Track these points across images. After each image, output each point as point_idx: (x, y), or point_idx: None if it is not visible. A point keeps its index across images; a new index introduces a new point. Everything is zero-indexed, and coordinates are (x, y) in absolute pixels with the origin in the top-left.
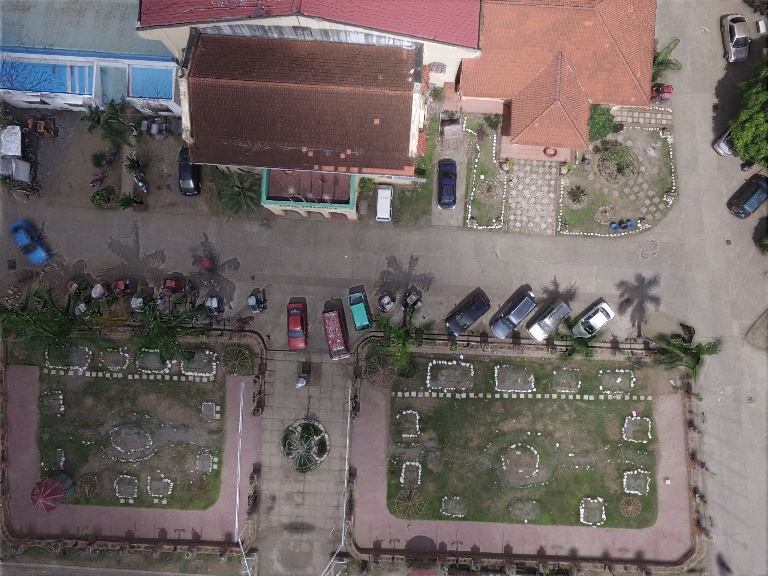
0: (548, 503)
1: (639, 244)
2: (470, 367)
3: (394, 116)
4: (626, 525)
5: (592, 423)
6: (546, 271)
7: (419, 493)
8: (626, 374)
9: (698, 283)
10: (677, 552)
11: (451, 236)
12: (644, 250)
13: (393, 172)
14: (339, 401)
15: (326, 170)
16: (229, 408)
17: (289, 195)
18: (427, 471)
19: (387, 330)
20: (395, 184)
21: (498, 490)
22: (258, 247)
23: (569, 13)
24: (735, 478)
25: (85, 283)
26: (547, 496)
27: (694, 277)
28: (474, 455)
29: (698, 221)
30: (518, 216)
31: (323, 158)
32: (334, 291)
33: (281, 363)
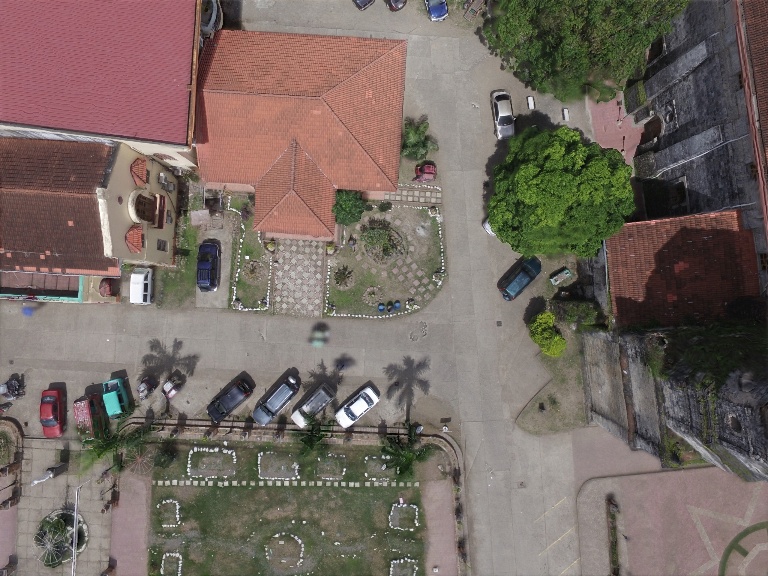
0: None
1: (408, 326)
2: (232, 455)
3: (88, 218)
4: None
5: (359, 510)
6: (313, 354)
7: None
8: None
9: (468, 365)
10: None
11: (216, 318)
12: (413, 332)
13: (98, 273)
14: (99, 490)
15: (29, 271)
16: None
17: (22, 286)
18: (188, 562)
19: (150, 416)
20: (157, 266)
21: None
22: (17, 331)
23: (295, 102)
24: (505, 565)
25: None
26: None
27: (464, 359)
28: (237, 545)
29: (468, 302)
30: (284, 297)
31: (23, 259)
32: (95, 376)
33: (39, 451)
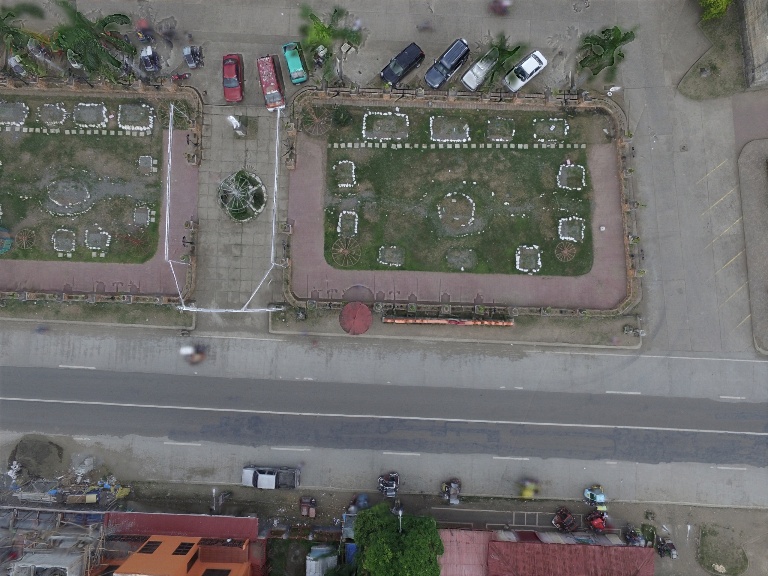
0: (484, 252)
1: None
2: (405, 117)
3: None
4: (562, 272)
5: (527, 172)
6: (480, 25)
7: (355, 240)
8: (560, 122)
9: None
10: (613, 298)
11: None
12: (577, 3)
13: None
14: None
15: None
16: (166, 162)
17: None
18: (364, 221)
19: None
20: None
21: (435, 239)
22: (195, 5)
23: None
24: (669, 225)
25: (22, 41)
26: (483, 245)
27: (626, 29)
28: (410, 205)
29: None
30: None
31: None
32: (270, 48)
33: (218, 117)
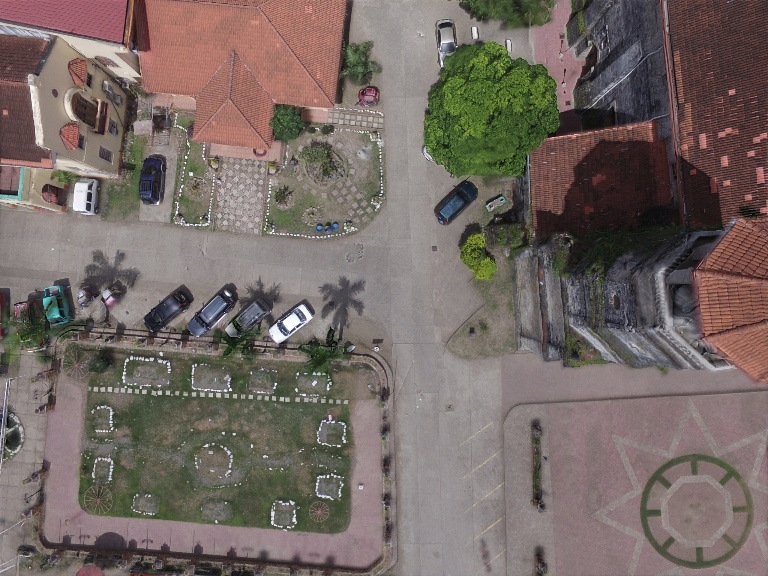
0: (240, 504)
1: (345, 247)
2: (166, 364)
3: (21, 107)
4: (318, 530)
5: (288, 425)
6: (251, 271)
7: (108, 489)
8: (322, 377)
9: (402, 288)
10: (368, 559)
11: (158, 232)
12: (350, 253)
13: (32, 164)
14: None
15: None
16: None
17: None
18: (120, 467)
19: None
20: (103, 178)
21: (191, 489)
22: None
23: (233, 11)
24: (430, 486)
25: None
26: (240, 497)
27: (398, 282)
28: (168, 453)
29: (405, 226)
30: (225, 214)
31: None
32: (39, 283)
33: None
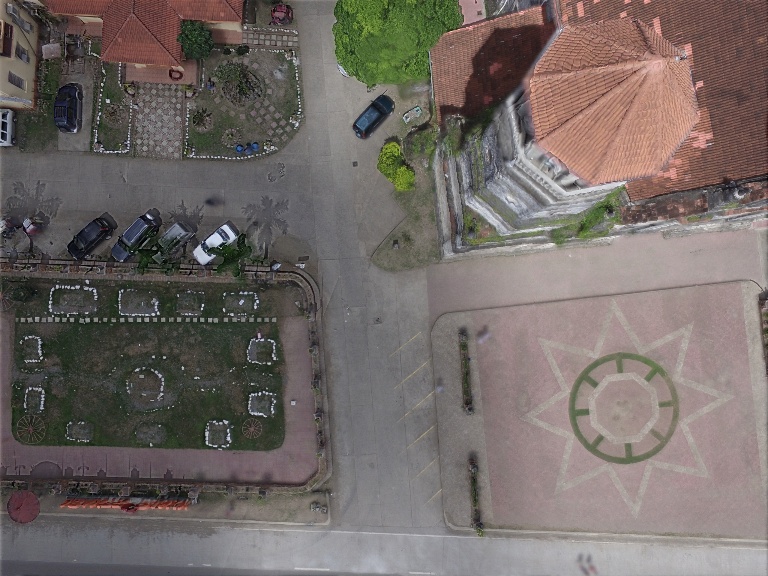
0: (174, 427)
1: (266, 167)
2: (93, 291)
3: None
4: (253, 447)
5: (218, 346)
6: (174, 195)
7: (40, 418)
8: (249, 296)
9: (325, 205)
10: (304, 473)
11: (78, 161)
12: (271, 173)
13: None
14: None
15: None
16: None
17: None
18: (51, 396)
19: (14, 256)
20: (19, 109)
21: (124, 414)
22: None
23: None
24: (362, 399)
25: None
26: (173, 420)
27: (321, 199)
28: (99, 380)
29: (324, 143)
30: (145, 140)
31: None
32: None
33: None
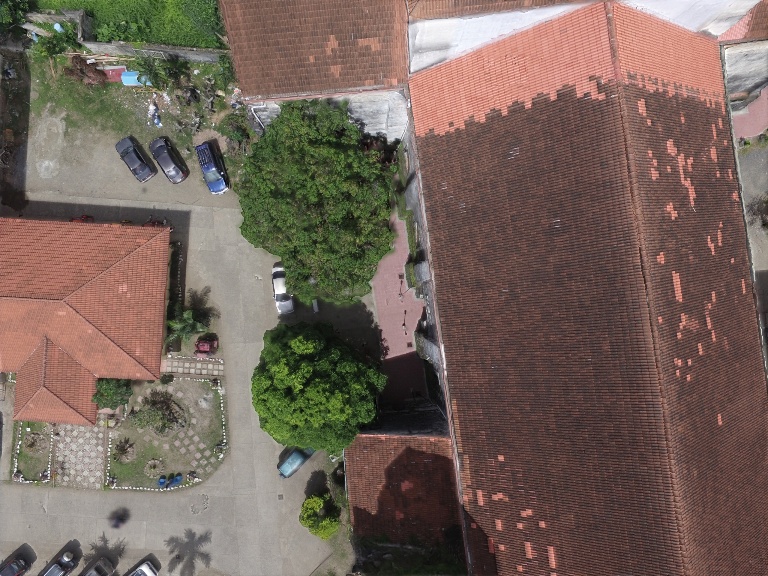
0: None
1: (190, 498)
2: None
3: None
4: None
5: None
6: (94, 526)
7: None
8: None
9: (249, 539)
10: None
11: None
12: (195, 505)
13: None
14: None
15: None
16: None
17: None
18: None
19: None
20: None
21: None
22: None
23: (38, 305)
24: None
25: None
26: None
27: (245, 533)
28: None
29: (249, 475)
30: (66, 470)
31: None
32: None
33: None
